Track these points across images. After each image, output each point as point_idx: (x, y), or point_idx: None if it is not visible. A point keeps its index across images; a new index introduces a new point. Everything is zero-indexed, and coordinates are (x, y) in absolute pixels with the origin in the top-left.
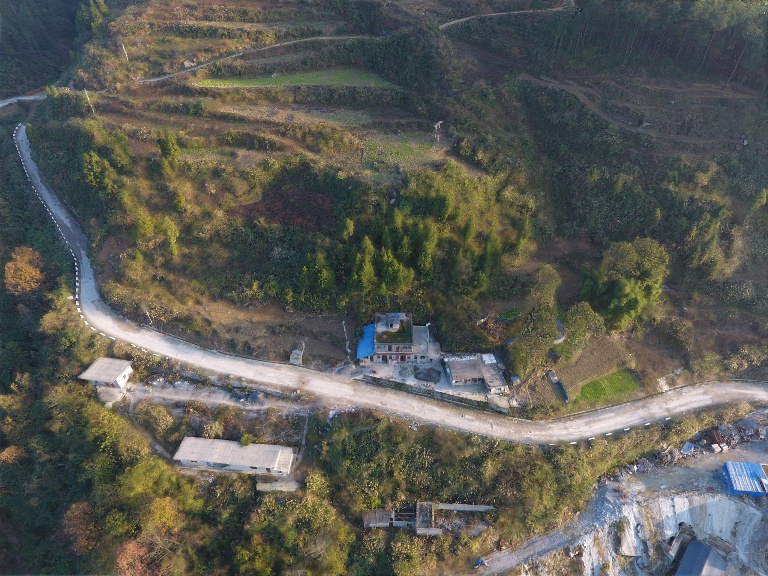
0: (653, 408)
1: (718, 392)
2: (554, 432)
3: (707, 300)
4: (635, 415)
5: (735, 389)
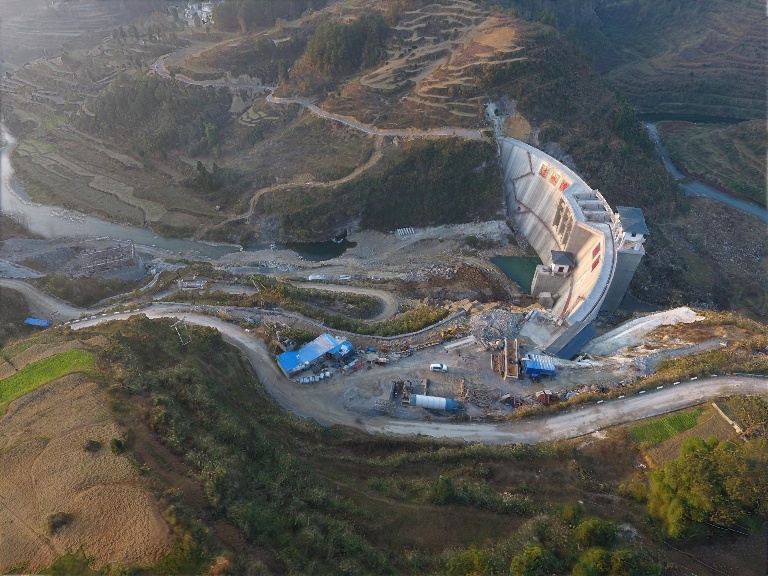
0: (613, 413)
1: (536, 432)
2: (714, 387)
3: (556, 504)
4: (633, 406)
5: (514, 436)
